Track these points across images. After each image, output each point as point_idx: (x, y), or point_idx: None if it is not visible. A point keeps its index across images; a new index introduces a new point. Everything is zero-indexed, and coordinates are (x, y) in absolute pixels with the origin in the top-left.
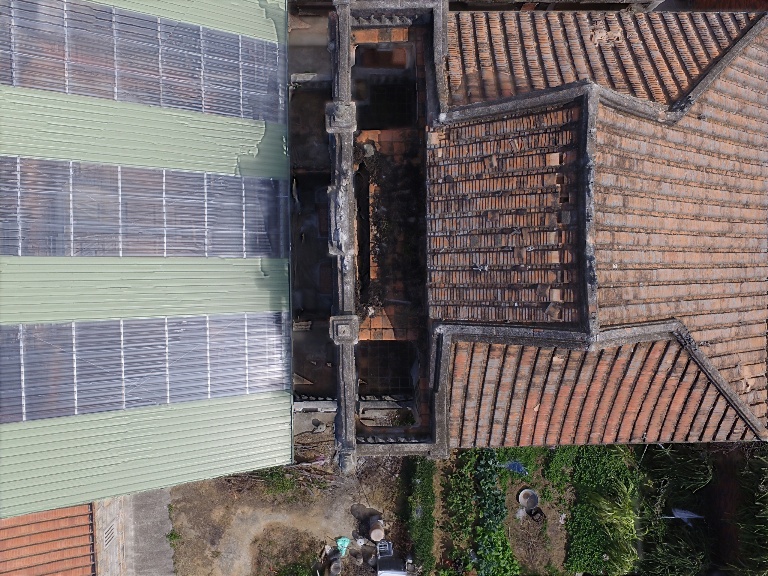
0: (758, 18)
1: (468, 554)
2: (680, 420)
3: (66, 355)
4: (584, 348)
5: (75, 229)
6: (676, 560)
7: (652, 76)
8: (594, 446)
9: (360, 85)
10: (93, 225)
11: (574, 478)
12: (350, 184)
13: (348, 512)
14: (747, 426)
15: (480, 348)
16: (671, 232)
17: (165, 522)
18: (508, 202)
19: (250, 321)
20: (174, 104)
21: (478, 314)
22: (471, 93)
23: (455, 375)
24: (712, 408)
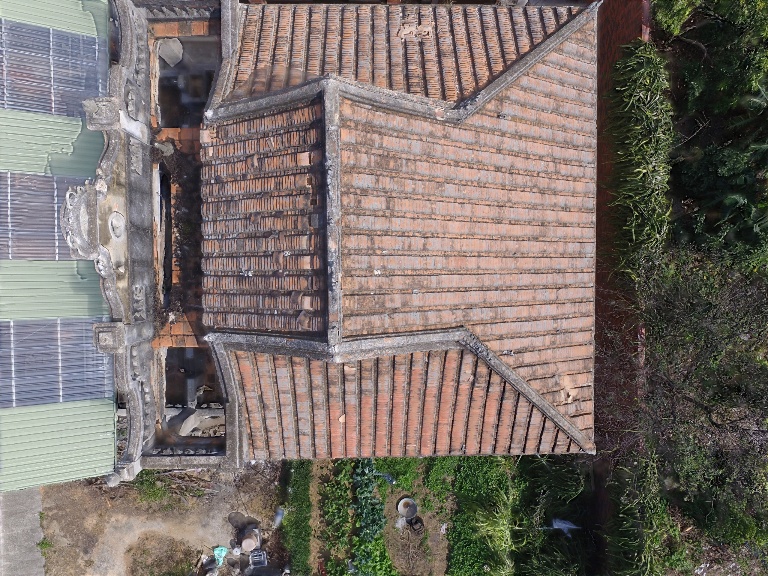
0: (579, 12)
1: (346, 564)
2: (498, 432)
3: None
4: (330, 359)
5: None
6: (550, 572)
7: (450, 72)
8: None
9: (197, 81)
10: None
11: (455, 487)
12: (108, 184)
13: (226, 520)
14: (570, 438)
15: (262, 357)
16: (461, 236)
17: (36, 530)
18: (267, 204)
19: (64, 326)
20: None
21: (243, 322)
22: (255, 89)
23: (245, 385)
24: (529, 419)
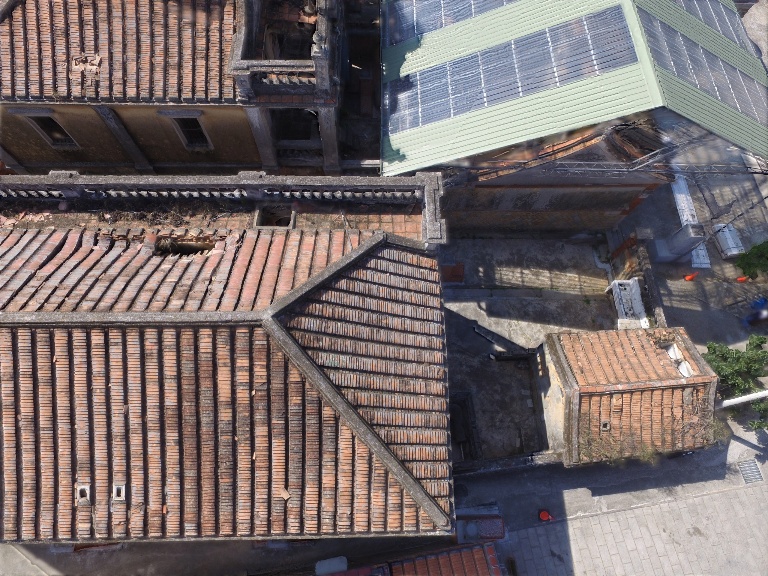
0: None
1: None
2: None
3: None
4: None
5: None
6: None
7: (57, 5)
8: None
9: None
10: None
11: None
12: None
13: None
14: None
15: None
16: None
17: None
18: None
19: None
20: None
21: None
22: None
23: None
24: None
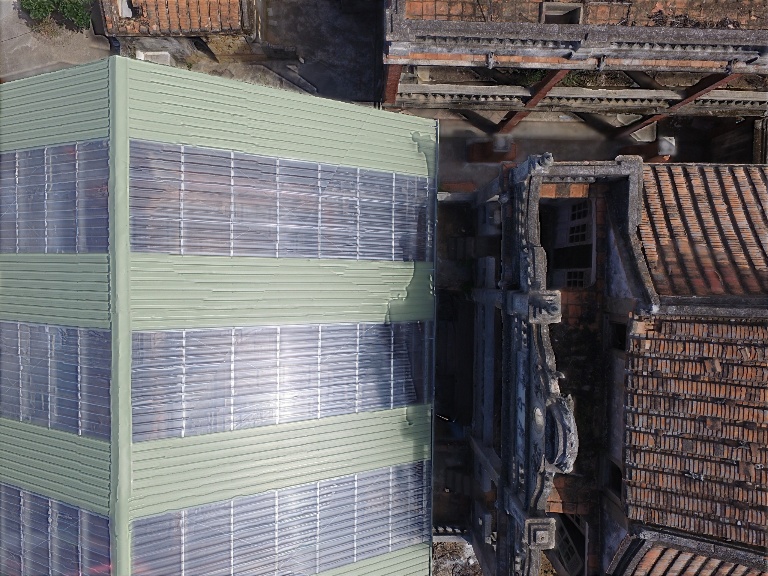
0: None
1: None
2: None
3: (224, 537)
4: None
5: (236, 401)
6: None
7: None
8: None
9: None
10: (252, 394)
11: None
12: (557, 383)
13: None
14: None
15: None
16: None
17: None
18: (734, 413)
19: (394, 474)
20: (331, 254)
21: (691, 526)
22: (672, 272)
23: (640, 566)
24: None
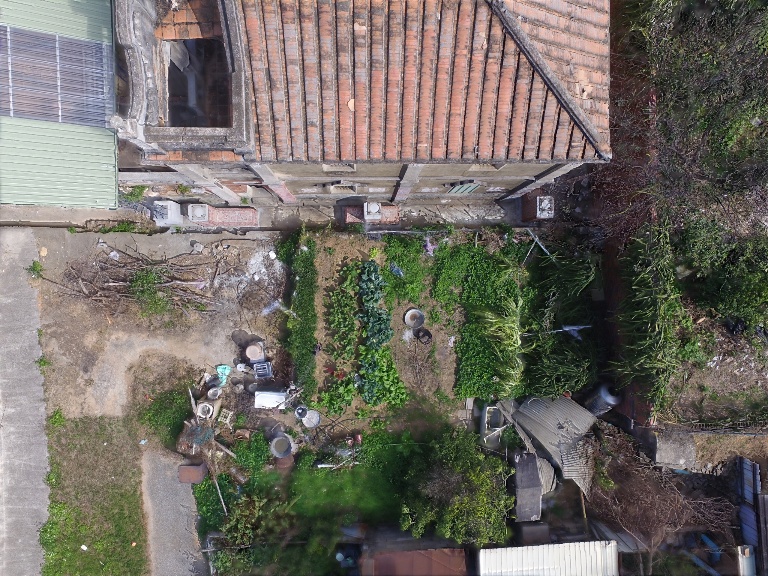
0: None
1: None
2: (511, 128)
3: None
4: None
5: None
6: (561, 368)
7: None
8: (483, 263)
9: None
10: None
11: (462, 297)
12: None
13: (229, 338)
14: (585, 139)
15: (269, 6)
16: None
17: (34, 347)
18: None
19: (63, 45)
20: None
21: None
22: None
23: (251, 50)
24: (543, 111)
